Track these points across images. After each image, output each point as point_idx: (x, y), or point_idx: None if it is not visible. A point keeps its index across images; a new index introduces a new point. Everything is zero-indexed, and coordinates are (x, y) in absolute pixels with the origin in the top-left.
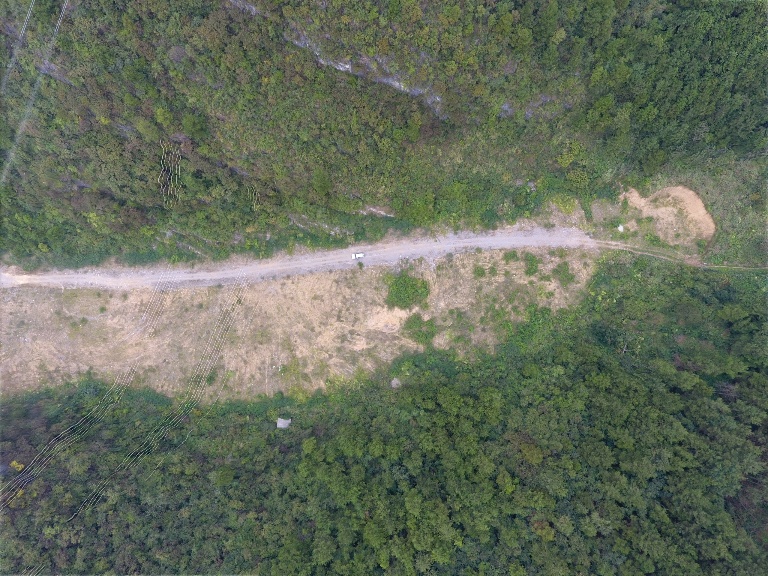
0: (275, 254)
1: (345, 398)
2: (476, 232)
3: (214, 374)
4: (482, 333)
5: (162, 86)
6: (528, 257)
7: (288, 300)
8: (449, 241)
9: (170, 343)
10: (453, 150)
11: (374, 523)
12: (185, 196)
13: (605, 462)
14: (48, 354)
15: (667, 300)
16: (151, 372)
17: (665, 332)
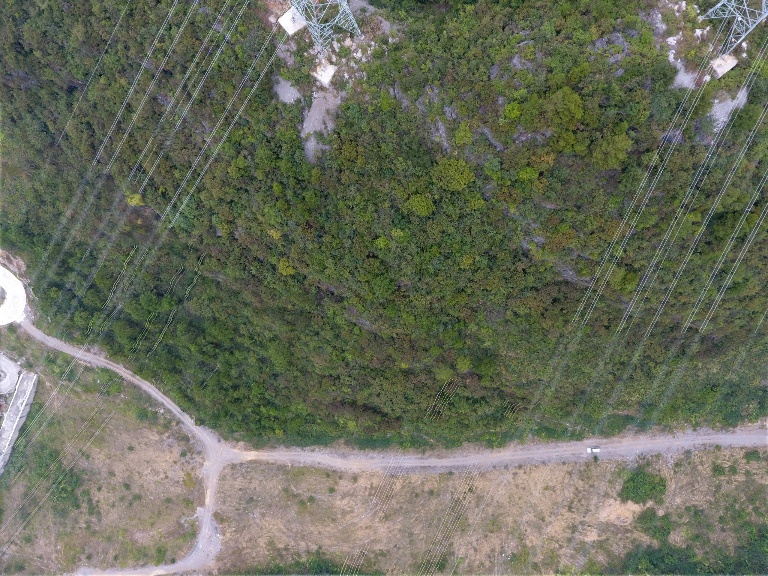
0: (507, 444)
1: None
2: (716, 429)
3: (444, 561)
4: (721, 533)
5: (468, 338)
6: None
7: (520, 490)
8: (688, 438)
9: (401, 528)
10: (713, 362)
11: None
12: (449, 412)
13: None
14: (277, 532)
15: None
16: (382, 556)
17: None
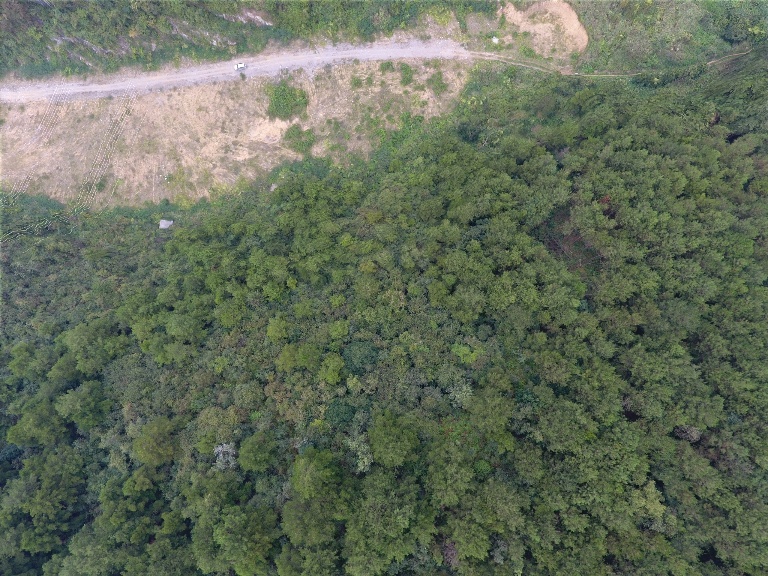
0: (162, 66)
1: (225, 203)
2: (354, 44)
3: (104, 181)
4: (357, 141)
5: None
6: (402, 66)
7: (174, 111)
8: (328, 53)
9: (63, 151)
10: None
11: (216, 270)
12: None
13: (435, 213)
14: None
15: (530, 98)
16: (45, 179)
17: (522, 123)
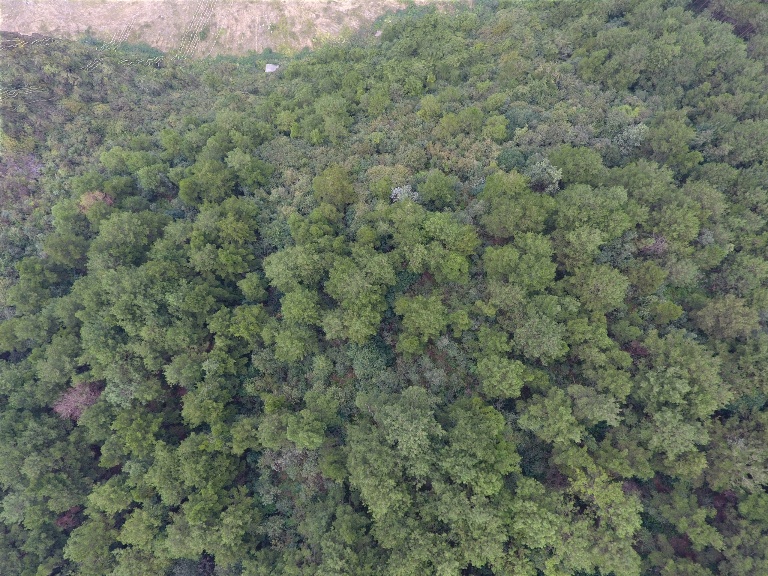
0: None
1: (330, 49)
2: None
3: (206, 30)
4: None
5: None
6: None
7: None
8: None
9: (165, 0)
10: None
11: None
12: None
13: None
14: (49, 15)
15: None
16: (147, 27)
17: None
